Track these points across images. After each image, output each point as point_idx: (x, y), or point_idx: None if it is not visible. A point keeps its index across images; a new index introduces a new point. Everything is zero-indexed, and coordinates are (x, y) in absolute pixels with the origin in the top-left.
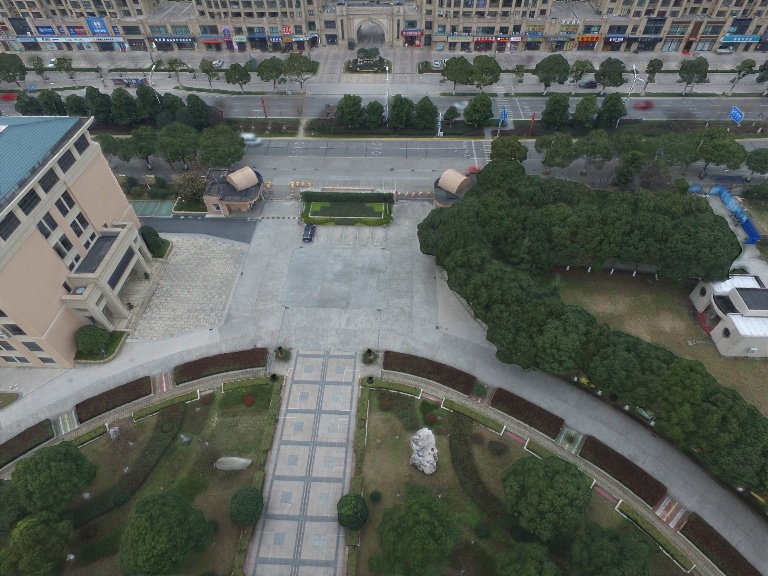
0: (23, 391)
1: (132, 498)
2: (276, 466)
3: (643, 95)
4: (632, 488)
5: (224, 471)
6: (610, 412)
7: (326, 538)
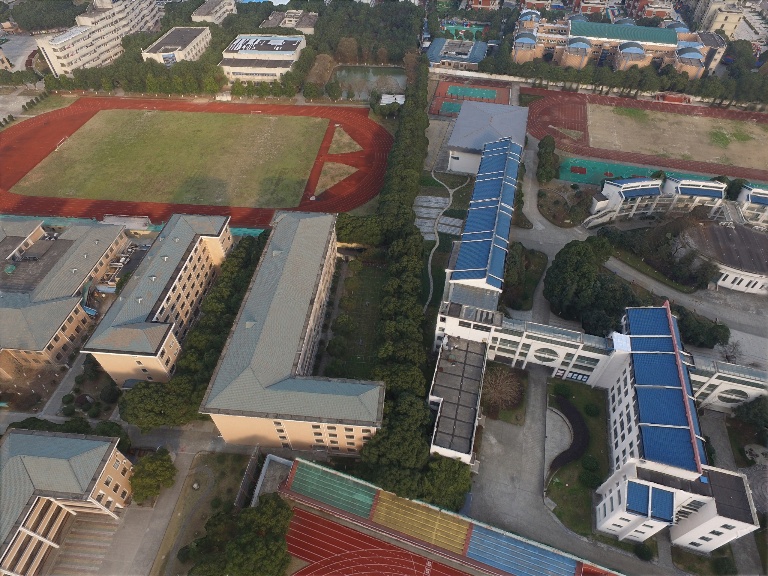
0: None
1: None
2: None
3: None
4: None
5: None
6: None
7: None
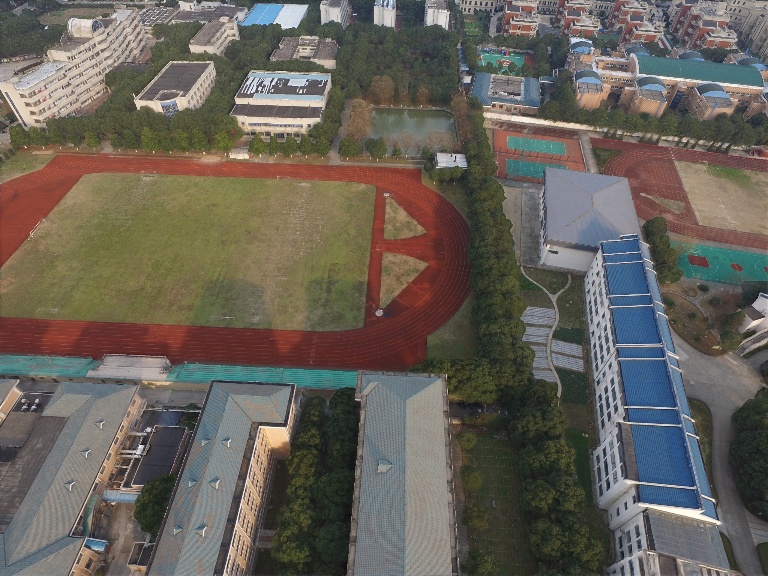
0: None
1: None
2: None
3: None
4: None
5: None
6: None
7: None
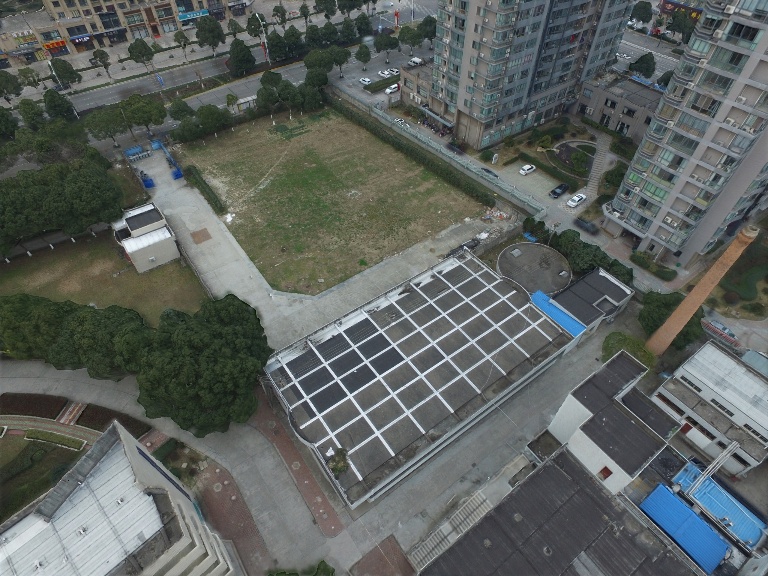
0: None
1: None
2: None
3: (112, 83)
4: (35, 415)
5: None
6: (31, 364)
7: None
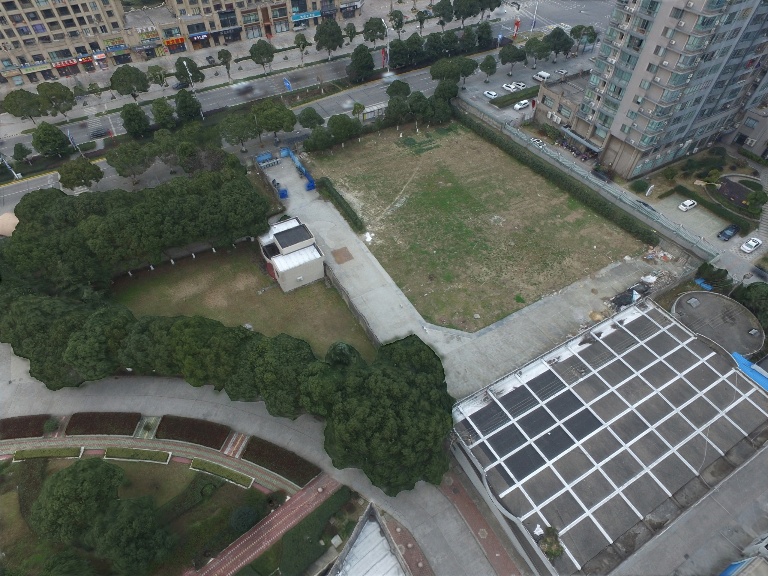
0: None
1: None
2: None
3: (231, 83)
4: (200, 443)
5: None
6: (188, 384)
7: None
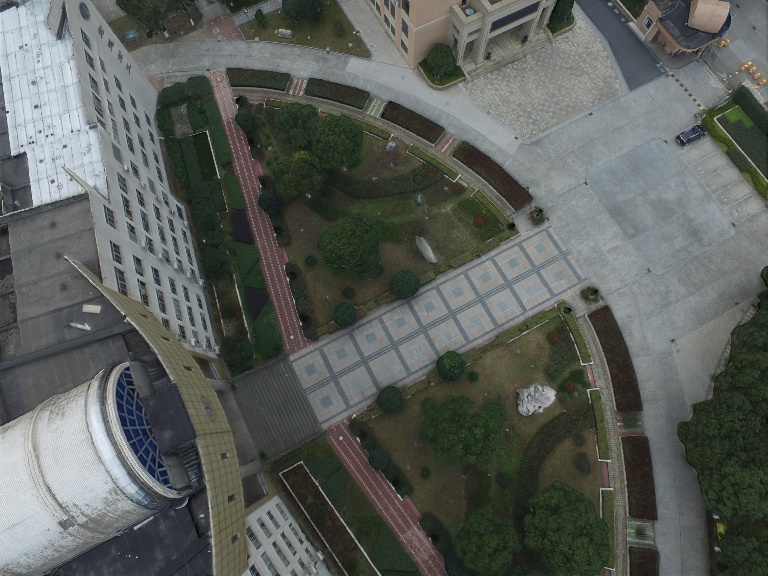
0: (375, 55)
1: (361, 200)
2: (445, 282)
3: None
4: None
5: (417, 247)
6: (702, 567)
7: (422, 356)
